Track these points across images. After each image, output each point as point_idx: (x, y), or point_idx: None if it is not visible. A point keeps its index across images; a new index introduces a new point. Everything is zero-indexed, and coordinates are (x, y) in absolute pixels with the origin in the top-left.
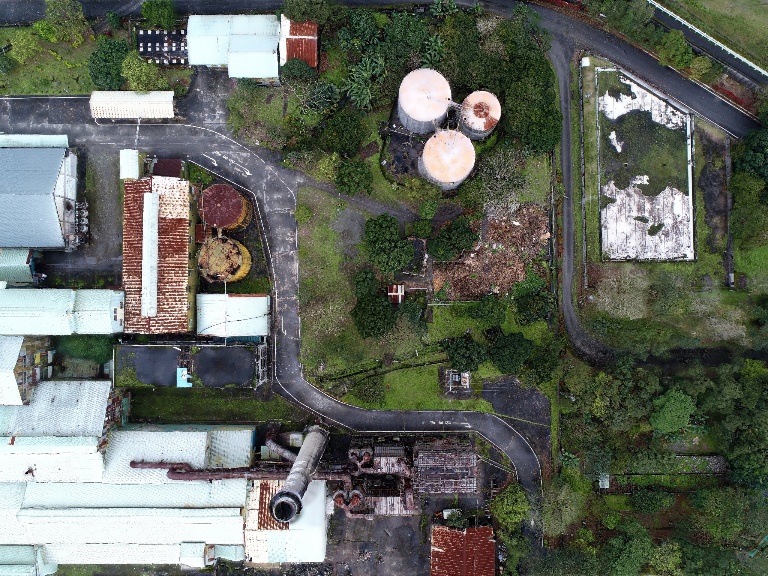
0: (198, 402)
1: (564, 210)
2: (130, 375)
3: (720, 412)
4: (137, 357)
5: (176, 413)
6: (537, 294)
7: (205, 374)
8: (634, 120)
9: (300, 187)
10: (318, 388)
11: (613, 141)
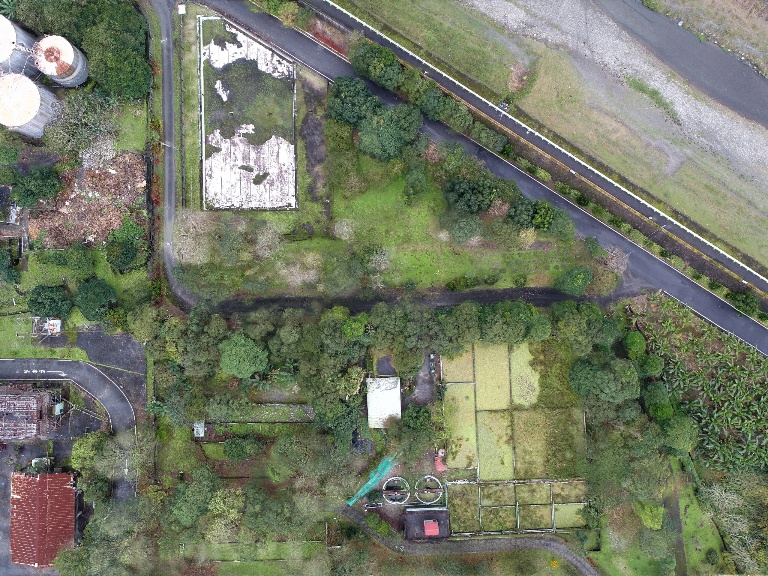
0: None
1: (166, 159)
2: None
3: (292, 357)
4: None
5: None
6: (131, 242)
7: None
8: (240, 69)
9: None
10: None
11: (219, 90)
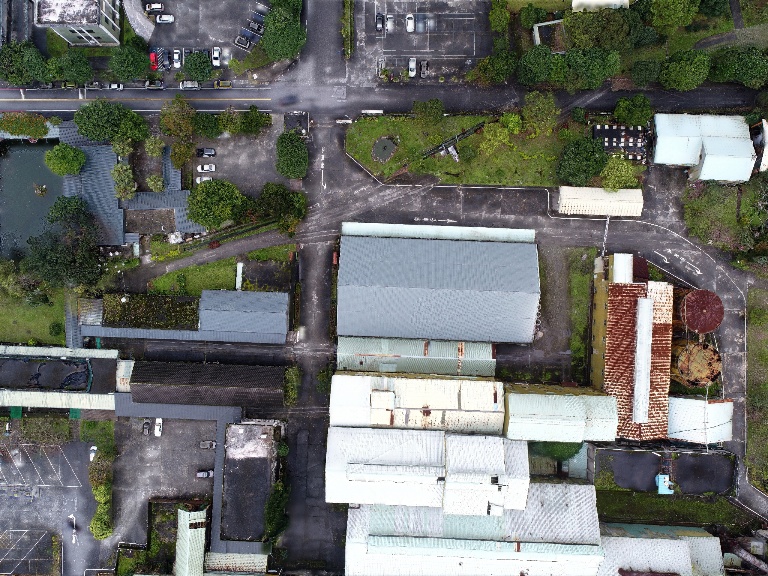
0: (642, 501)
1: None
2: (608, 479)
3: None
4: (615, 461)
5: (620, 511)
6: None
7: (684, 481)
8: None
9: (750, 288)
10: (763, 492)
11: None
